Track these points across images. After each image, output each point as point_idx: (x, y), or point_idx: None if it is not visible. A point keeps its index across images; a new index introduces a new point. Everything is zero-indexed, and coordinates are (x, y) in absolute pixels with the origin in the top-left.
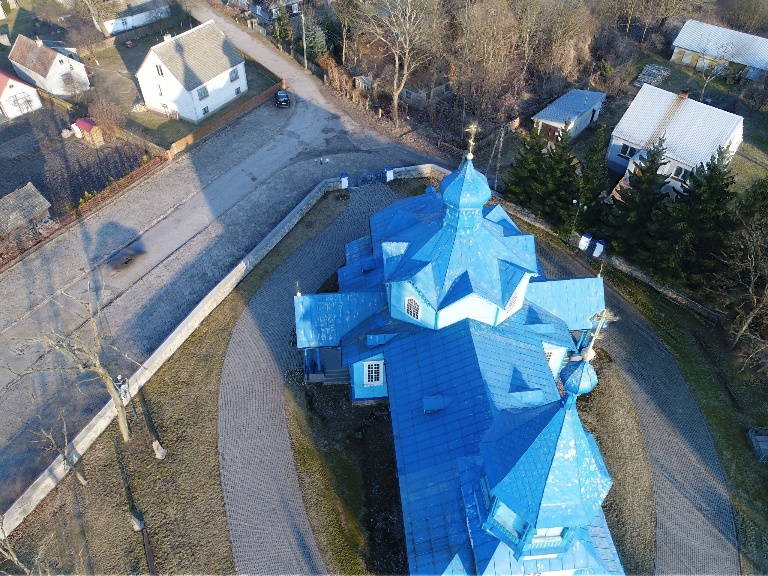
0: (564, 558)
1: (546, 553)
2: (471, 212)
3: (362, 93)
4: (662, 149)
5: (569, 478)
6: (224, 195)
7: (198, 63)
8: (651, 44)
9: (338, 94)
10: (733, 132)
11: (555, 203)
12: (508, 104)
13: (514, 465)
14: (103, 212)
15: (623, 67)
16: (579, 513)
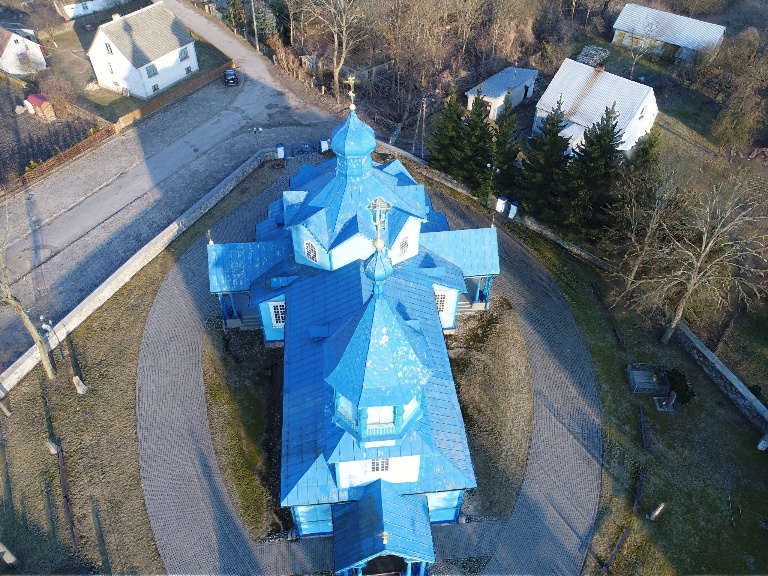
0: (402, 446)
1: (383, 439)
2: (358, 160)
3: (308, 72)
4: (560, 112)
5: (386, 363)
6: (166, 165)
7: (147, 42)
8: (593, 27)
9: (286, 73)
10: (643, 102)
11: (472, 168)
12: (445, 81)
13: (342, 355)
14: (48, 180)
15: (558, 47)
16: (397, 395)
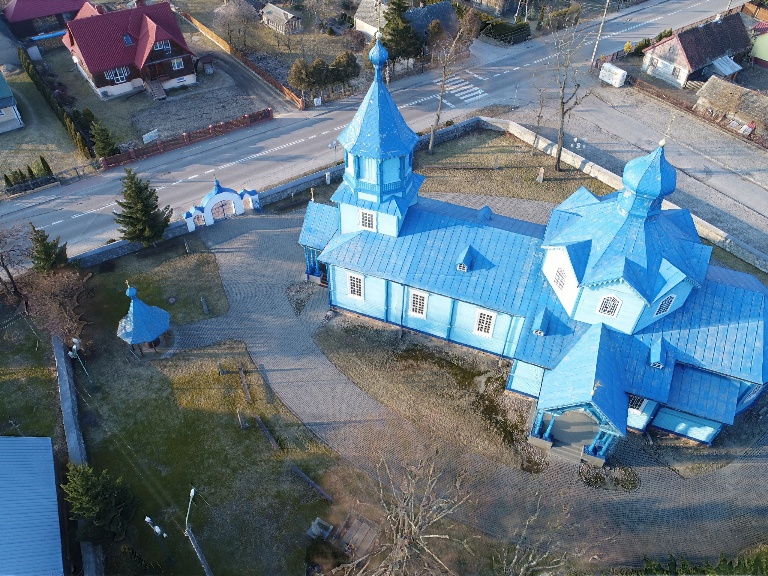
0: None
1: None
2: None
3: None
4: None
5: None
6: None
7: None
8: None
9: None
10: None
11: None
12: None
13: None
14: None
15: None
16: None
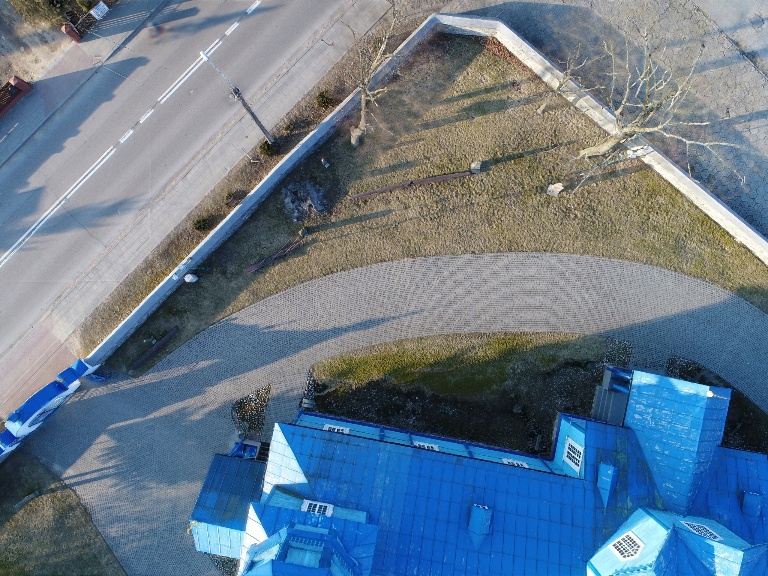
0: None
1: None
2: None
3: None
4: None
5: None
6: None
7: None
8: None
9: None
10: None
11: None
12: None
13: None
14: None
15: None
16: None
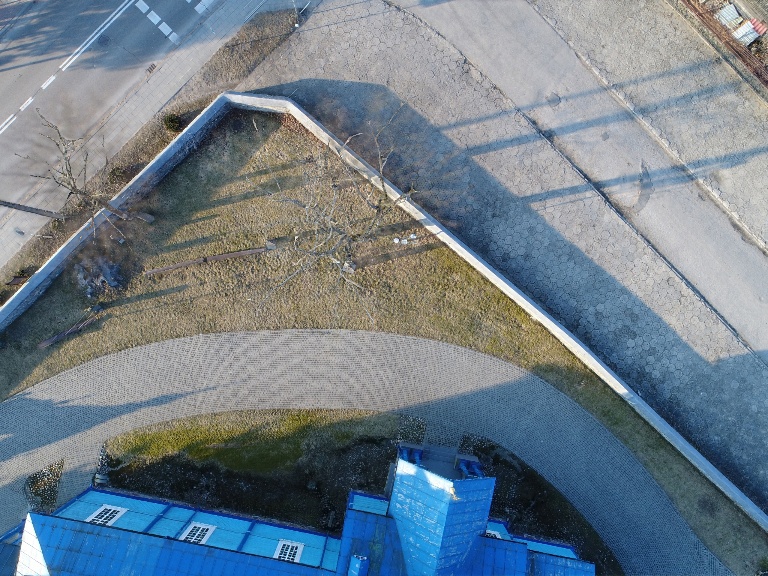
0: None
1: None
2: None
3: None
4: None
5: None
6: None
7: None
8: None
9: None
10: None
11: None
12: None
13: None
14: None
15: None
16: None
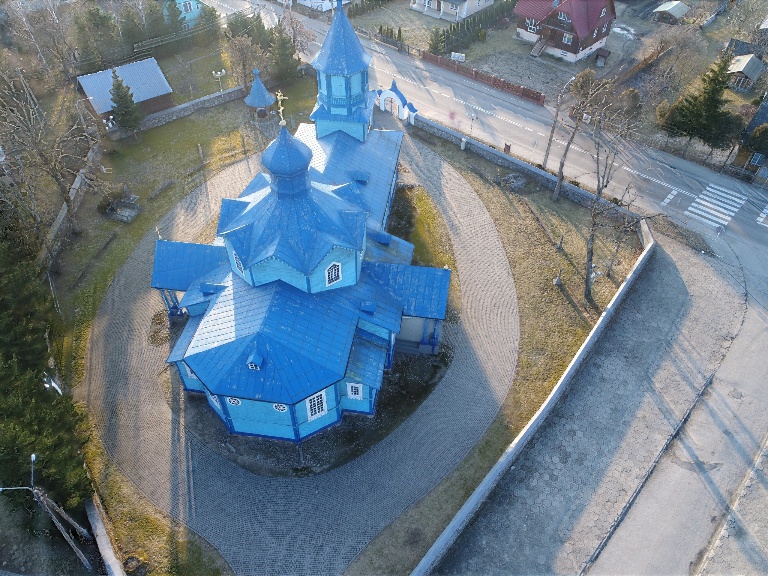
0: None
1: None
2: None
3: None
4: None
5: None
6: None
7: None
8: None
9: None
10: None
11: None
12: None
13: None
14: None
15: None
16: None
